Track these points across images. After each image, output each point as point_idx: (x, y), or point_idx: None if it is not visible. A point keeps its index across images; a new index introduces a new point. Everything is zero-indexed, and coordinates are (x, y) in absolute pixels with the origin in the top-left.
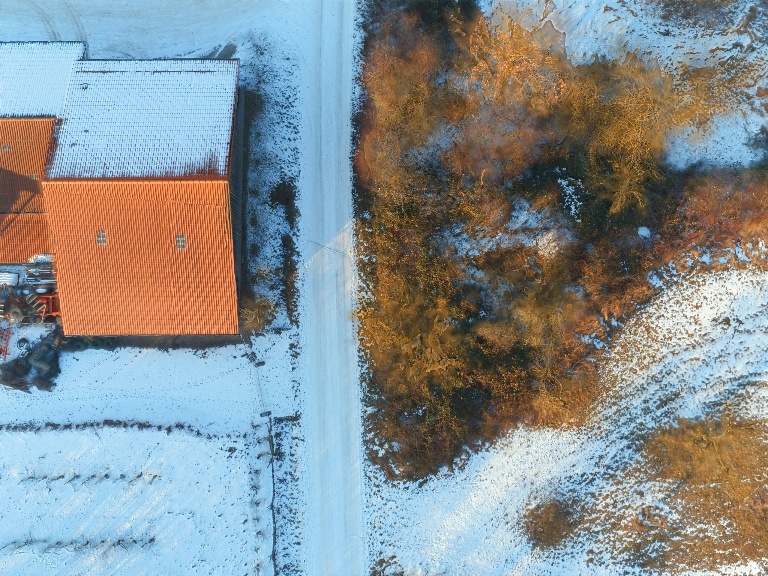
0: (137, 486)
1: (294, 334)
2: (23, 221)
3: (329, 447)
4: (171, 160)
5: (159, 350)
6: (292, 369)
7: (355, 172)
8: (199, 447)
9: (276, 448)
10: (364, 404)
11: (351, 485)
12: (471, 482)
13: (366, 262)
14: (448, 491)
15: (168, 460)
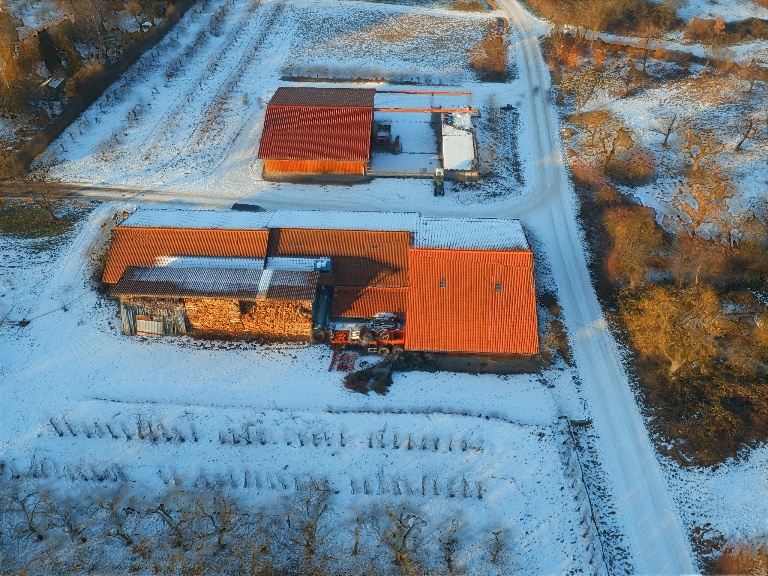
0: (463, 456)
1: (574, 371)
2: (374, 292)
3: (622, 443)
4: (491, 246)
5: (470, 374)
6: (578, 391)
7: (597, 290)
8: (513, 431)
9: (576, 442)
10: (644, 415)
11: (649, 470)
12: (758, 469)
13: (619, 333)
14: (740, 474)
15: (488, 438)
